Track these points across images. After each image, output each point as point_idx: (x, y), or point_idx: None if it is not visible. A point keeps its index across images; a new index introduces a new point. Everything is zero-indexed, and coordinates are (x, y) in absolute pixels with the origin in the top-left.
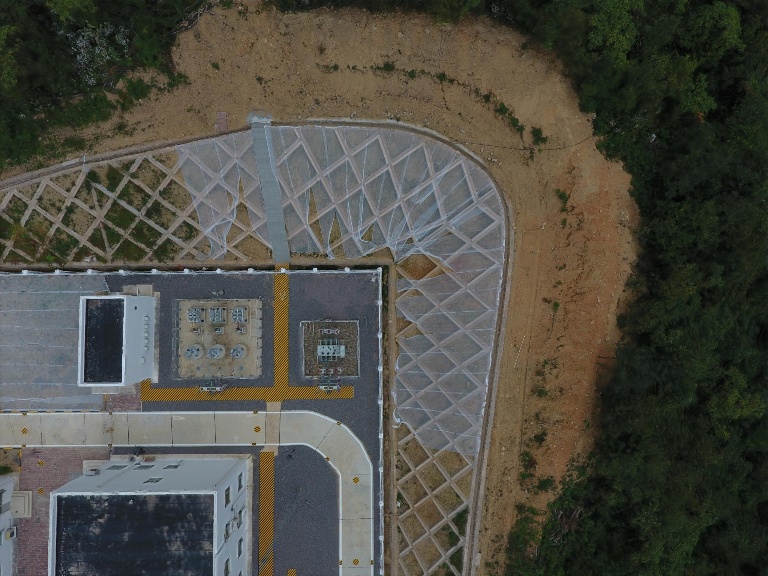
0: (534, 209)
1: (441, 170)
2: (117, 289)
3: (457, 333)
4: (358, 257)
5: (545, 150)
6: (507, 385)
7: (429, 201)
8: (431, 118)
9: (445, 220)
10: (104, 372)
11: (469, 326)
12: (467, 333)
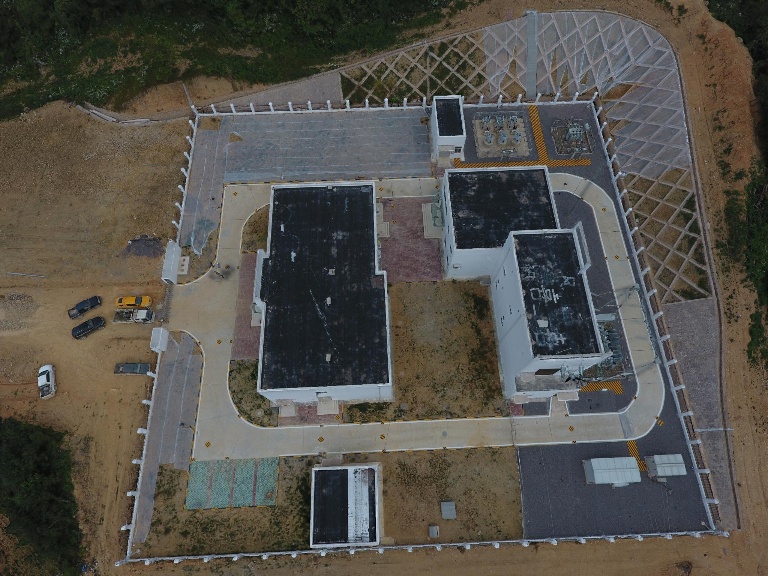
0: (686, 46)
1: (630, 33)
2: None
3: (657, 110)
4: None
5: (687, 17)
6: (697, 128)
7: (622, 53)
8: (621, 8)
9: (633, 61)
10: (449, 134)
11: (664, 103)
12: (664, 107)
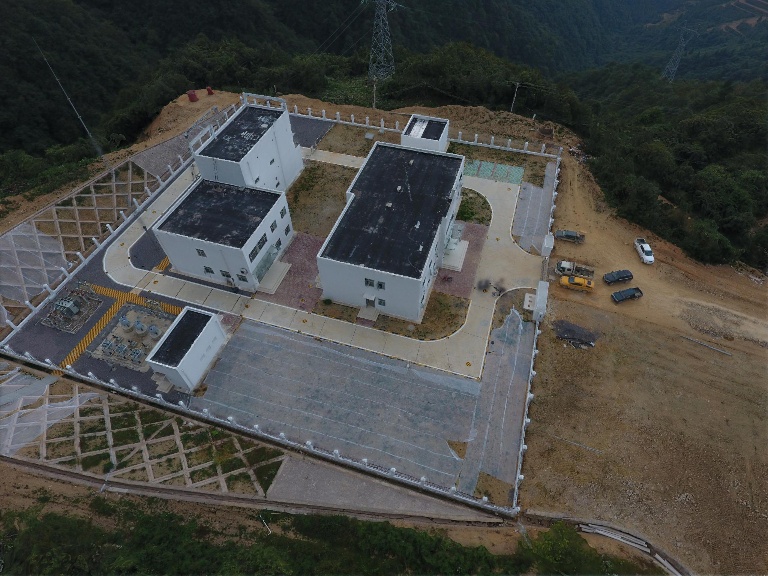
0: None
1: None
2: (185, 396)
3: None
4: (1, 363)
5: None
6: None
7: None
8: None
9: None
10: (199, 321)
11: None
12: None
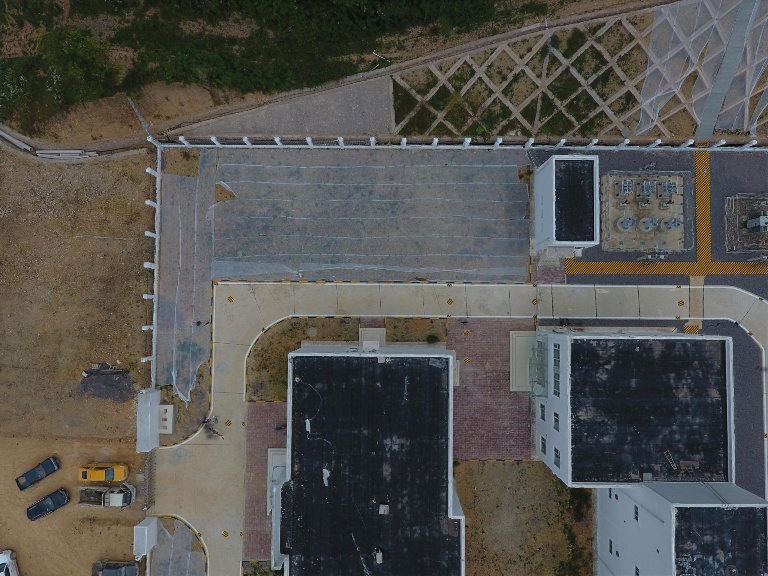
0: None
1: None
2: (539, 164)
3: None
4: None
5: None
6: None
7: None
8: None
9: None
10: (570, 232)
11: None
12: None
